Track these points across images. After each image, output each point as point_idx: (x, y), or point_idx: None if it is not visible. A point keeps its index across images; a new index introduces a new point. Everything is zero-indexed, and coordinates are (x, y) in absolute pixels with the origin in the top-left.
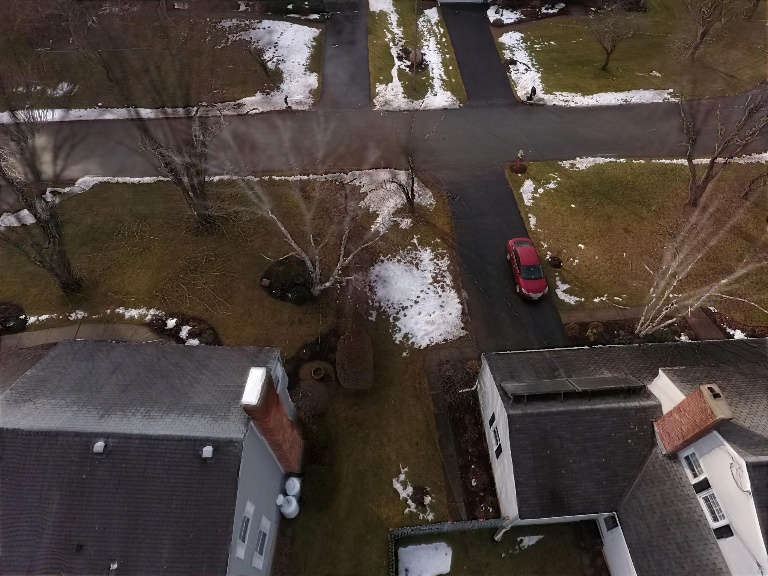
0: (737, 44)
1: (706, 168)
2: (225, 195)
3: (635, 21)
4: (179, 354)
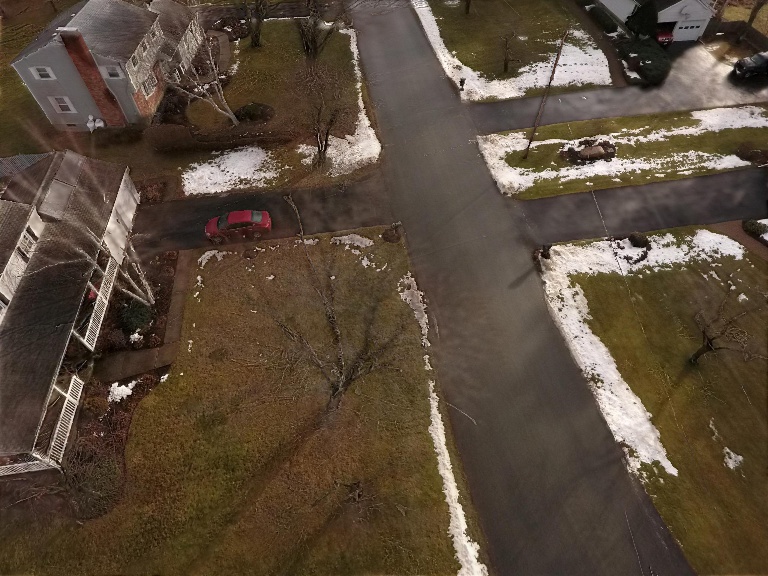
0: None
1: None
2: None
3: None
4: (133, 37)
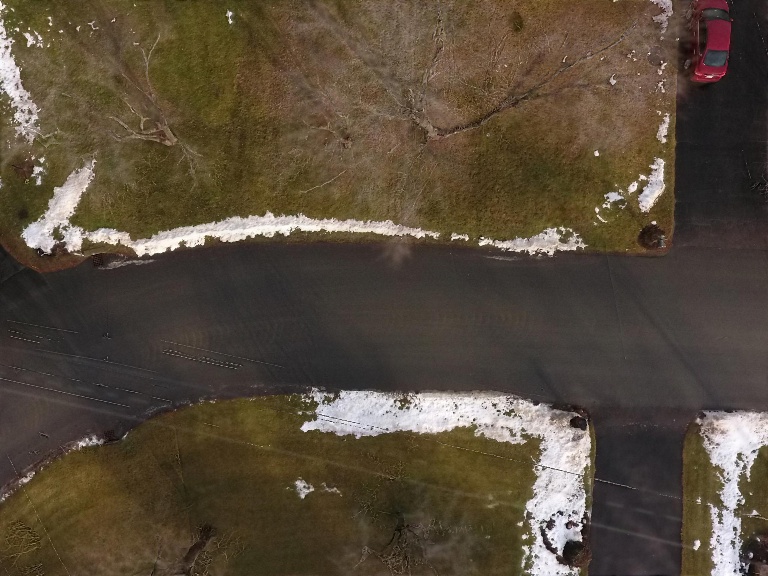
0: None
1: None
2: None
3: None
4: None
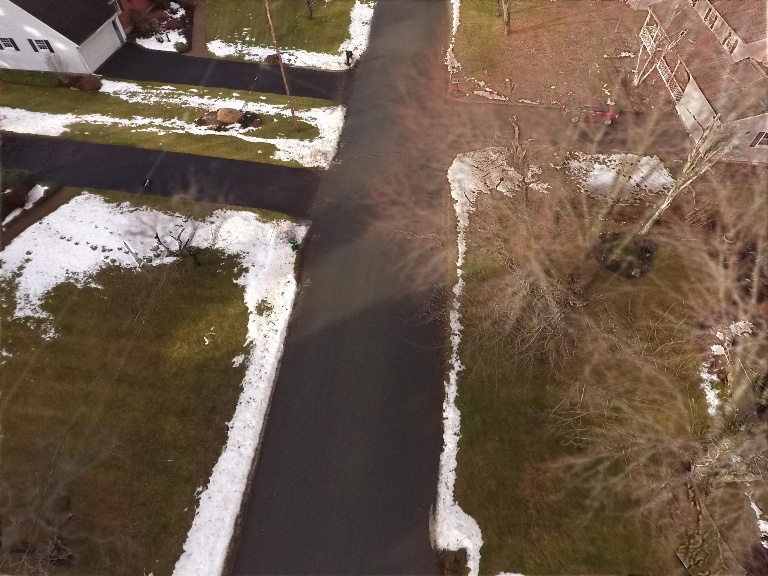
0: None
1: (505, 4)
2: (494, 315)
3: None
4: None
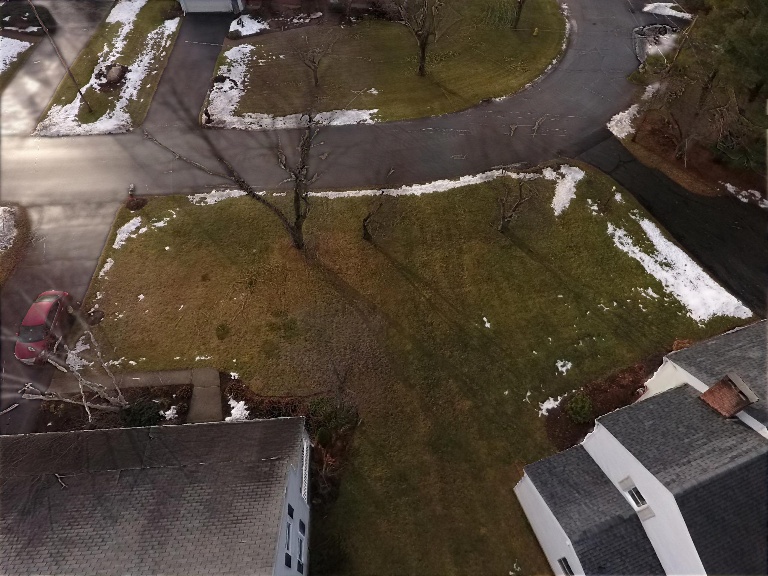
0: (485, 57)
1: None
2: None
3: (389, 31)
4: None
